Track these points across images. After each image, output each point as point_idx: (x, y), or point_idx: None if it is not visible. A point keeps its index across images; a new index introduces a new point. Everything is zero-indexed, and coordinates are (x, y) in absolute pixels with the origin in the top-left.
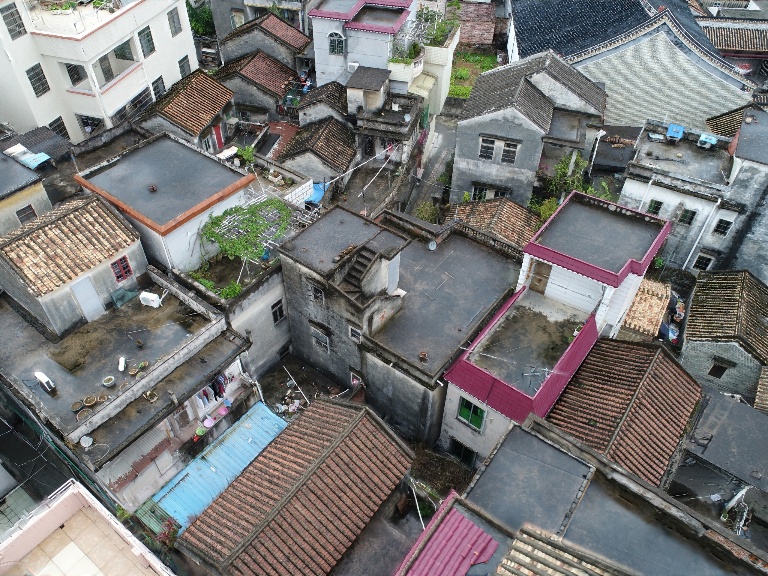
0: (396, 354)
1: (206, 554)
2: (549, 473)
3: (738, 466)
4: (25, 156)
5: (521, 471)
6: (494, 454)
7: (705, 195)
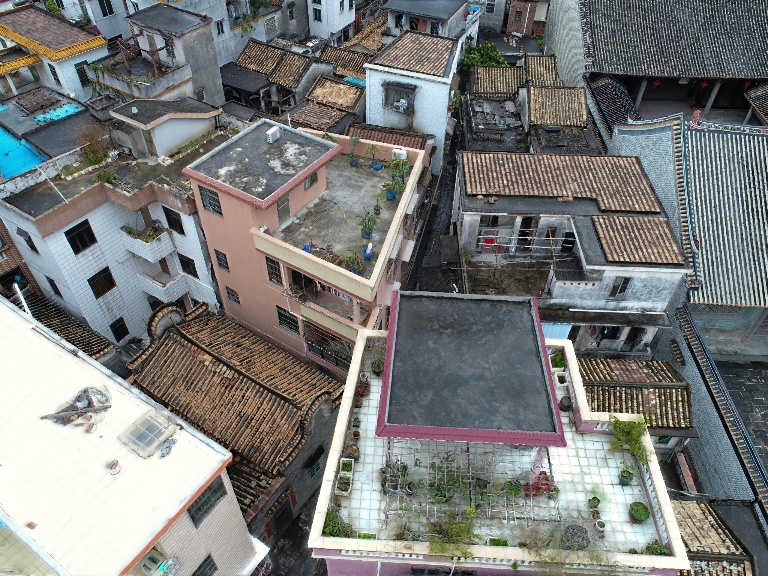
0: None
1: None
2: None
3: None
4: None
5: None
6: None
7: None
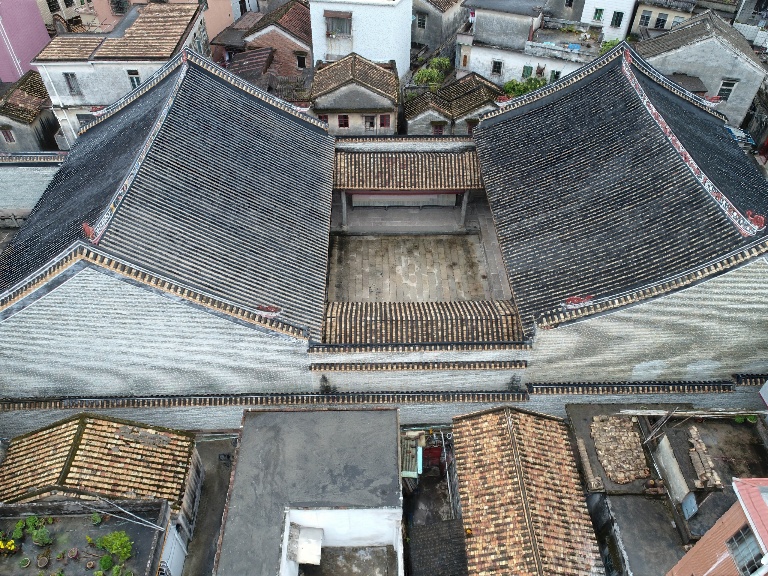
0: None
1: None
2: None
3: None
4: None
5: None
6: None
7: (550, 28)
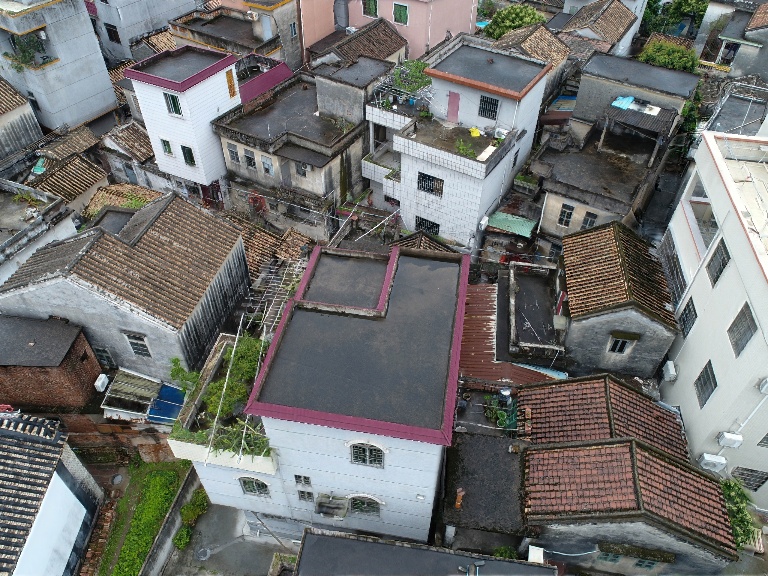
0: None
1: (391, 29)
2: (261, 0)
3: None
4: (635, 106)
5: (272, 0)
6: (281, 2)
7: None
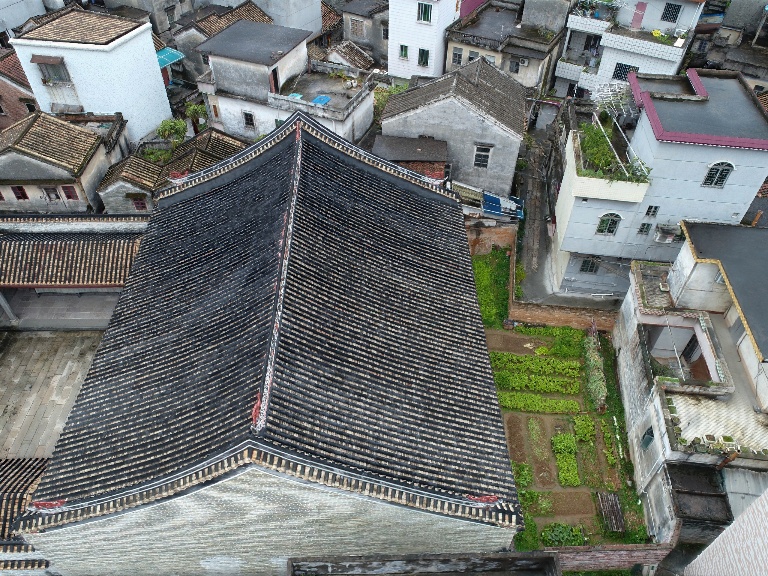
0: (510, 1)
1: None
2: None
3: (366, 1)
4: None
5: None
6: None
7: (320, 72)
